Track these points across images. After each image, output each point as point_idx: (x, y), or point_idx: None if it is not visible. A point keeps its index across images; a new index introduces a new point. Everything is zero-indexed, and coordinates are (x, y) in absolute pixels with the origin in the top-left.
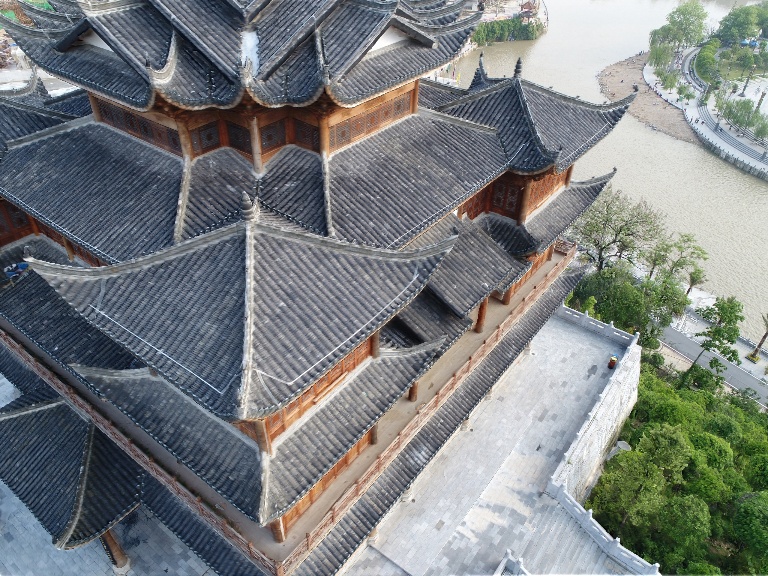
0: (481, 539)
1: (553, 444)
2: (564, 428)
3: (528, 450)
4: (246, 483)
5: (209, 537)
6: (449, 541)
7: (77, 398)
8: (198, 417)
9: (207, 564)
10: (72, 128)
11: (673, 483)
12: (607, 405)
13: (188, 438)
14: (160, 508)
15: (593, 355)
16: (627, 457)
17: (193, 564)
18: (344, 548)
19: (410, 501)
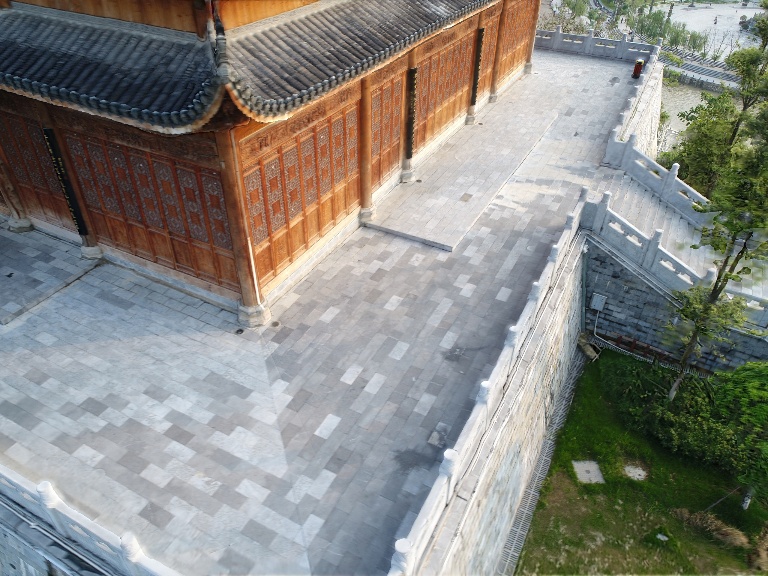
0: (531, 207)
1: (594, 130)
2: (602, 119)
3: (563, 136)
4: None
5: (55, 60)
6: (485, 212)
7: None
8: None
9: (51, 89)
10: None
11: None
12: (646, 102)
13: None
14: None
15: (610, 71)
16: None
17: (60, 264)
18: (335, 64)
19: (414, 181)
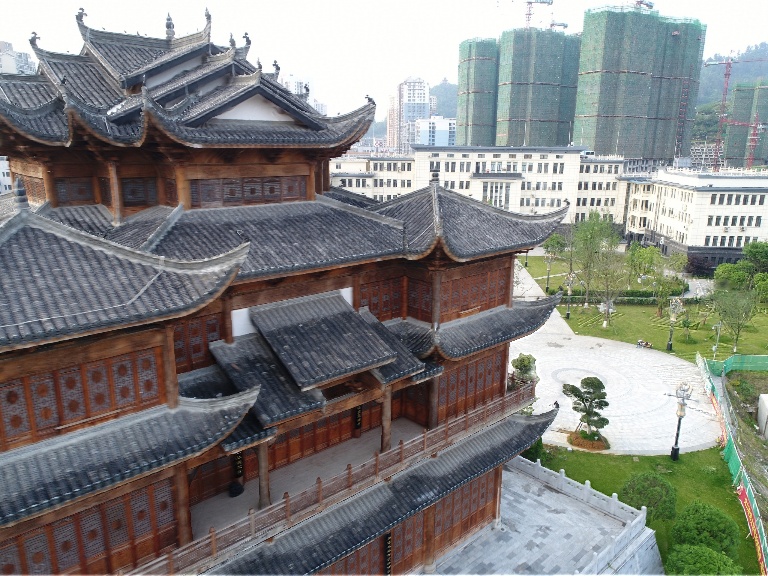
0: None
1: None
2: None
3: None
4: None
5: None
6: None
7: None
8: None
9: None
10: (349, 196)
11: None
12: None
13: None
14: None
15: None
16: None
17: None
18: None
19: None
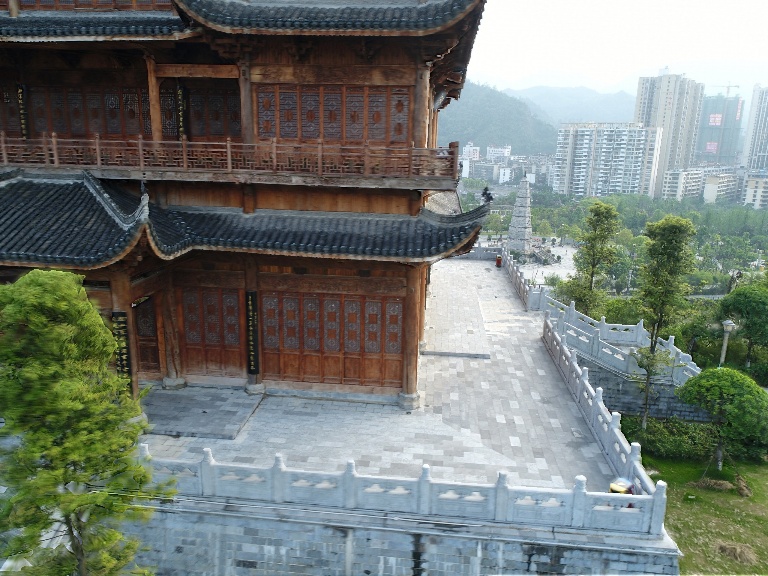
0: (511, 333)
1: (504, 294)
2: (502, 288)
3: (490, 299)
4: (424, 16)
5: (316, 235)
6: (487, 338)
7: (64, 141)
8: (325, 10)
9: (334, 247)
10: None
11: (614, 263)
12: None
13: (327, 17)
14: (229, 237)
15: (480, 265)
16: (564, 282)
17: (237, 400)
18: None
19: (429, 328)
